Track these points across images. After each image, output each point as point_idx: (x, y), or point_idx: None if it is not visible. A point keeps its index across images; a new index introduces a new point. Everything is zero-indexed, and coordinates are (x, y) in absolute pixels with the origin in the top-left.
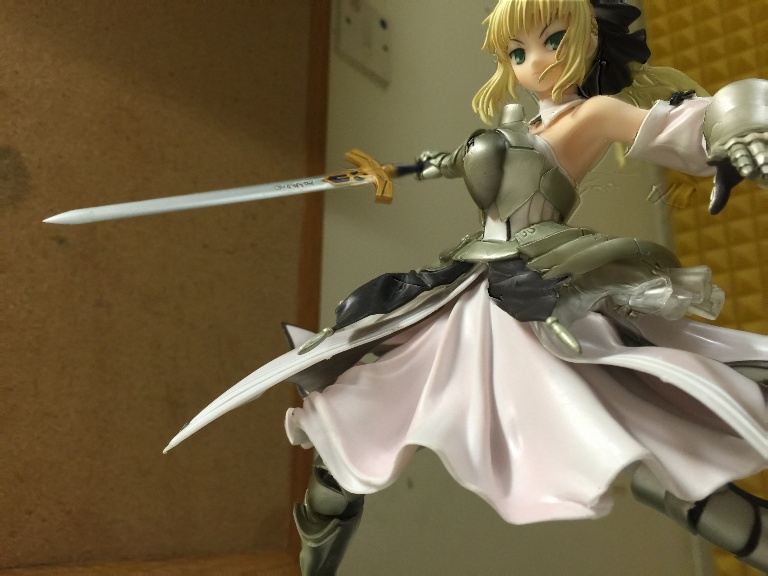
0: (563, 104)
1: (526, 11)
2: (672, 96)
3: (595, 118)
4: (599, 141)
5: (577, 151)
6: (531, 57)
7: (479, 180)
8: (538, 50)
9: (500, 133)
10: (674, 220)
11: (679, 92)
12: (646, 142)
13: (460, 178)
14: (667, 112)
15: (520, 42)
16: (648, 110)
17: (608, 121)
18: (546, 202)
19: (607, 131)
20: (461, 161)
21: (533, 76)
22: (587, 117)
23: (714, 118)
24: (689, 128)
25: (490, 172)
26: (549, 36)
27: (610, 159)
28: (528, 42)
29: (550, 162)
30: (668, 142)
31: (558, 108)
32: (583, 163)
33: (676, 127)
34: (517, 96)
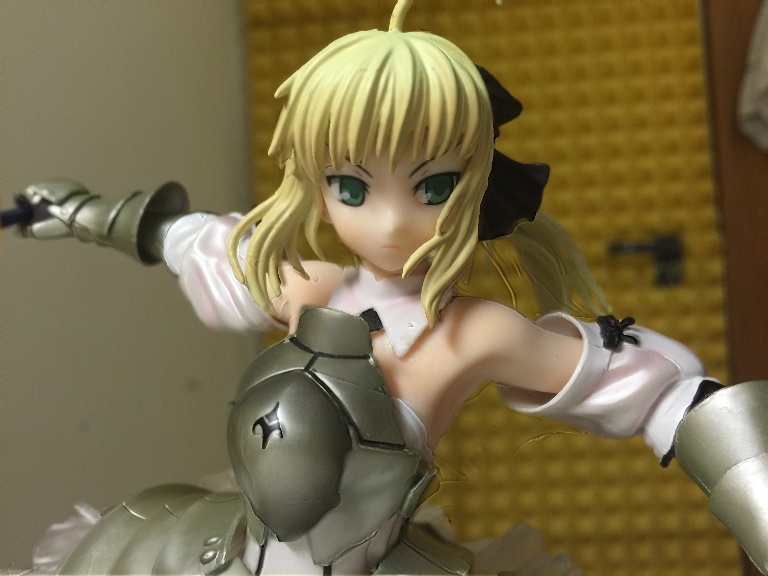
0: (419, 297)
1: (404, 126)
2: (600, 323)
3: (493, 359)
4: (479, 383)
5: (448, 407)
6: (386, 212)
7: (284, 503)
8: (401, 199)
9: (331, 396)
10: (519, 452)
11: (613, 321)
12: (563, 408)
13: (113, 251)
14: (606, 367)
15: (364, 170)
16: (566, 344)
17: (511, 365)
18: (398, 518)
19: (501, 375)
20: (126, 239)
21: (382, 248)
22: (482, 358)
23: (701, 422)
24: (641, 408)
25: (316, 498)
26: (427, 176)
27: (482, 402)
28: (384, 178)
29: (419, 452)
30: (598, 416)
31: (414, 310)
32: (449, 421)
33: (621, 401)
34: (322, 250)
